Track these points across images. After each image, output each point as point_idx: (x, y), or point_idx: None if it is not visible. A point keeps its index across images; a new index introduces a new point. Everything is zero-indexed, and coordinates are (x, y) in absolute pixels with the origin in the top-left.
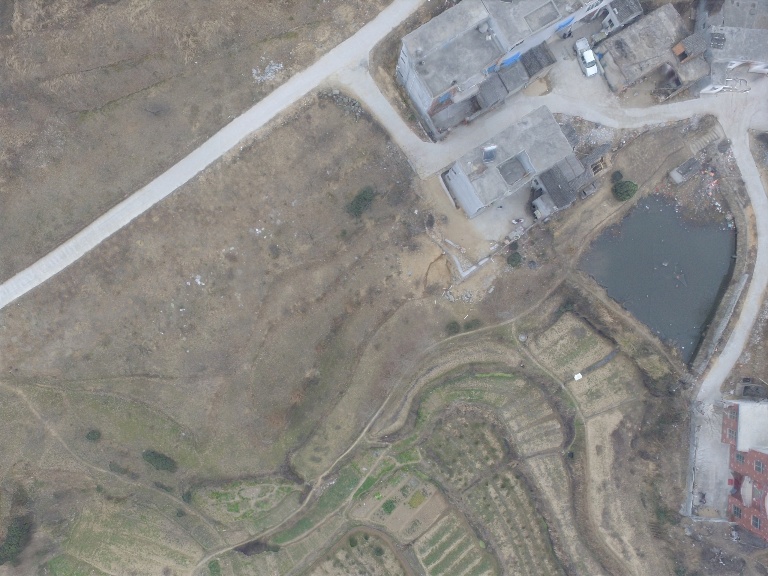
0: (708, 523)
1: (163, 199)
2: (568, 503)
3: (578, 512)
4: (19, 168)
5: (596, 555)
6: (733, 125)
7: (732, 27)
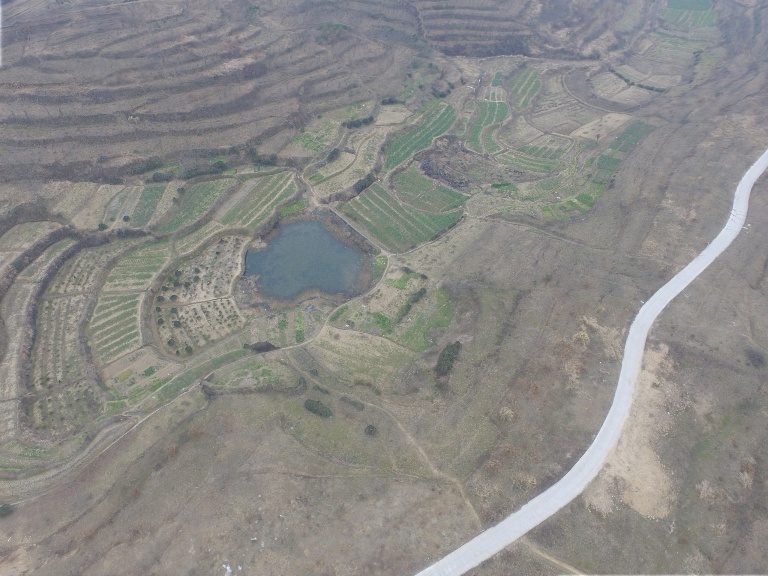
0: None
1: None
2: (3, 364)
3: None
4: None
5: (4, 330)
6: None
7: None
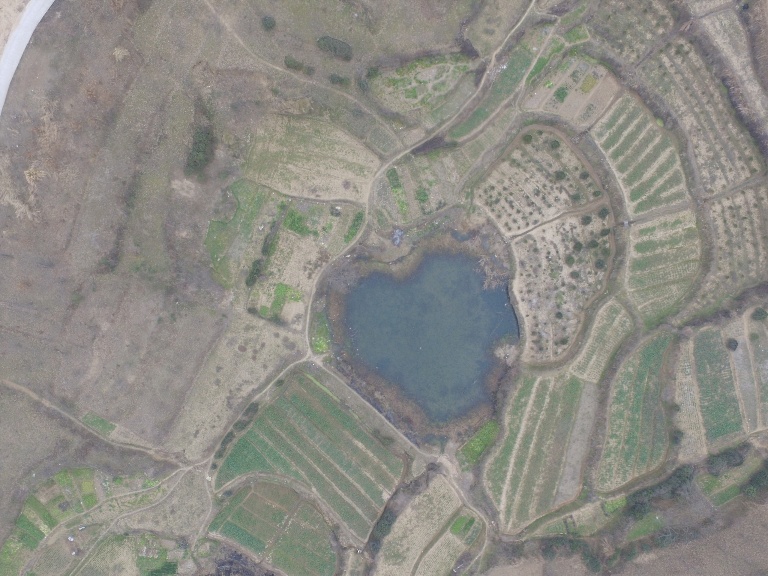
0: None
1: None
2: (748, 57)
3: (761, 61)
4: None
5: None
6: None
7: None
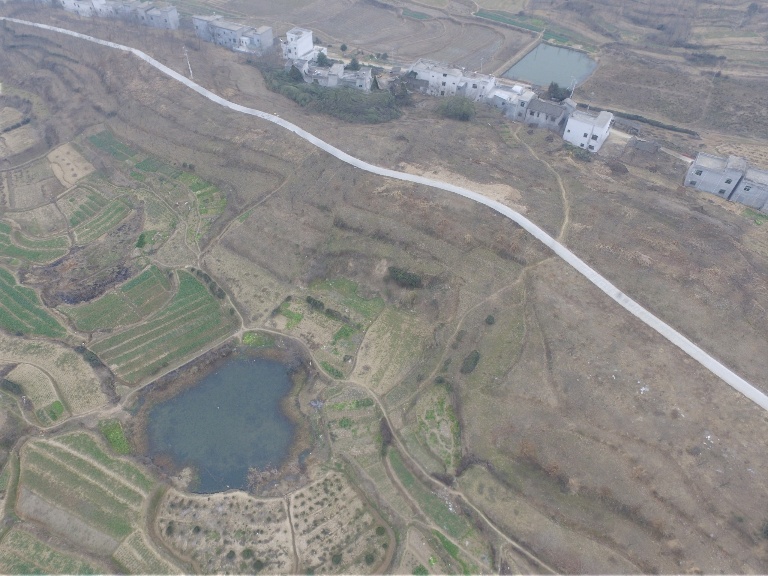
0: None
1: (706, 367)
2: None
3: None
4: (688, 284)
5: None
6: None
7: None
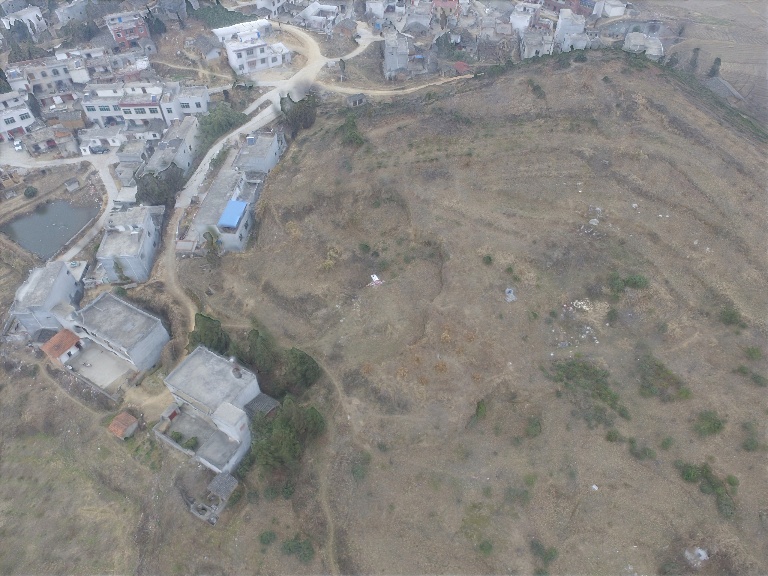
0: (17, 343)
1: None
2: None
3: None
4: None
5: None
6: (101, 165)
7: (92, 129)
